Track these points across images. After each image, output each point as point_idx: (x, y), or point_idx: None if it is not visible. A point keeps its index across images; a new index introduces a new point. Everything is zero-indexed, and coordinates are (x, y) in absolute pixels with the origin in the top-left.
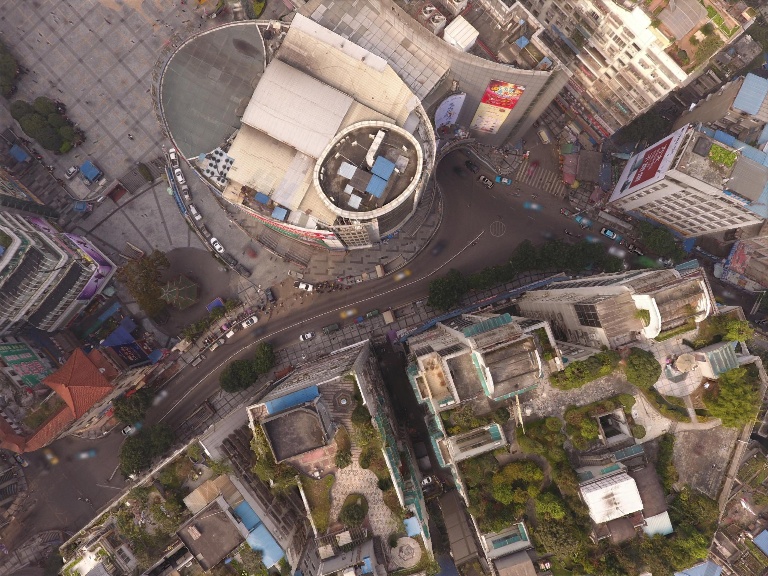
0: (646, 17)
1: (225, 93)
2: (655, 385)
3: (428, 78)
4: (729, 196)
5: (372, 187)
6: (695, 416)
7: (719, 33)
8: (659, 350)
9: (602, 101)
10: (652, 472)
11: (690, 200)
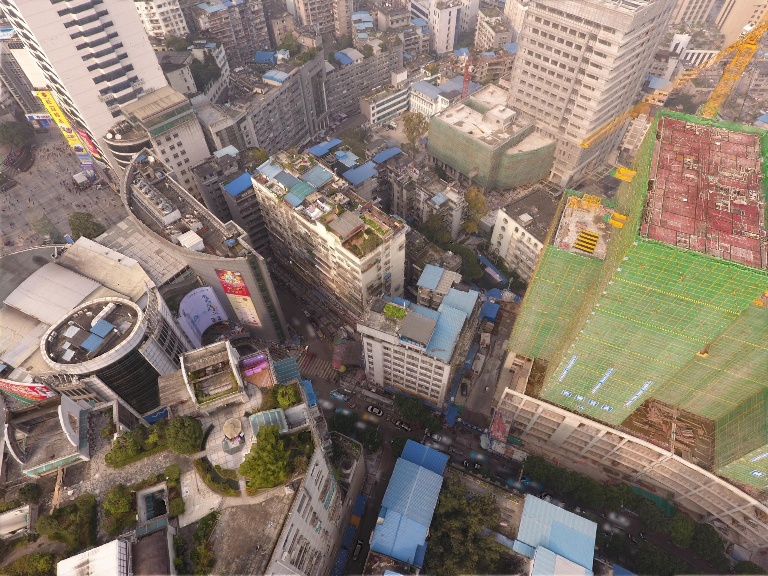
0: (322, 226)
1: (9, 289)
2: (210, 458)
3: (169, 271)
4: (409, 343)
5: (88, 343)
6: (245, 489)
7: (377, 233)
8: (221, 423)
9: (344, 297)
10: (158, 542)
11: (398, 357)
